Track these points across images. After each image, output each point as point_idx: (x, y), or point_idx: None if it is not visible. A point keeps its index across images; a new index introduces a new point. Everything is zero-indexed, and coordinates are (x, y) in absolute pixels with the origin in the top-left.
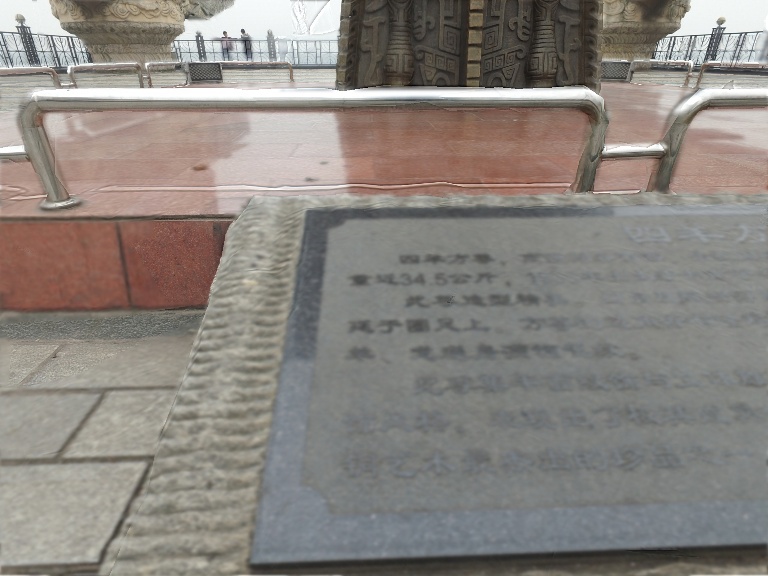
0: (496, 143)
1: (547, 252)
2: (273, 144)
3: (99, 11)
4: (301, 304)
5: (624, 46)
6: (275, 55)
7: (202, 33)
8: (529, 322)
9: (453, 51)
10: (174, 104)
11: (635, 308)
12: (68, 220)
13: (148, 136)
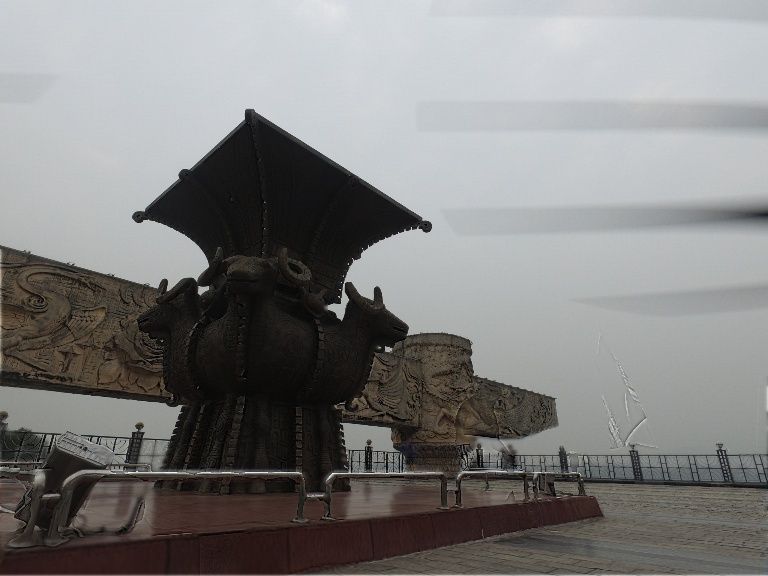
0: None
1: None
2: None
3: (410, 436)
4: None
5: None
6: (567, 468)
7: None
8: None
9: None
10: None
11: None
12: None
13: None
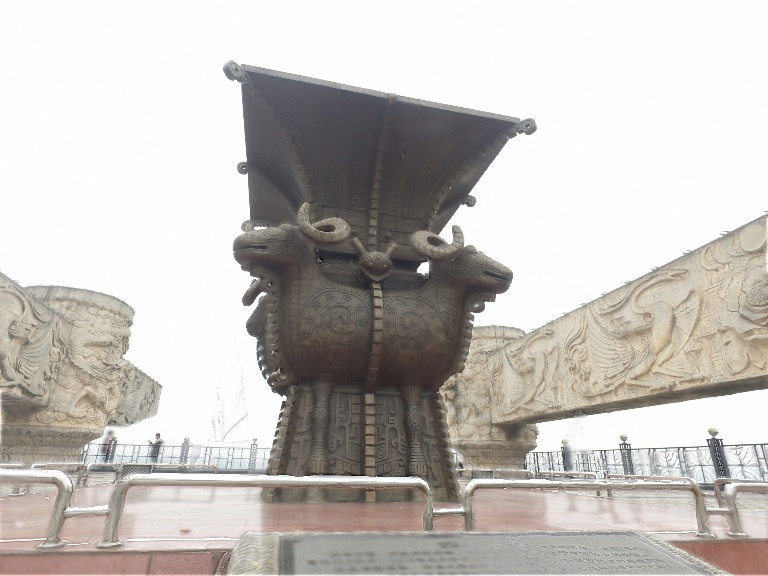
0: (385, 519)
1: (400, 551)
2: (228, 520)
3: (24, 416)
4: (284, 570)
5: (499, 459)
6: (186, 460)
7: (117, 438)
8: (388, 573)
9: (355, 459)
10: (208, 482)
11: (436, 569)
12: (119, 553)
13: (125, 516)
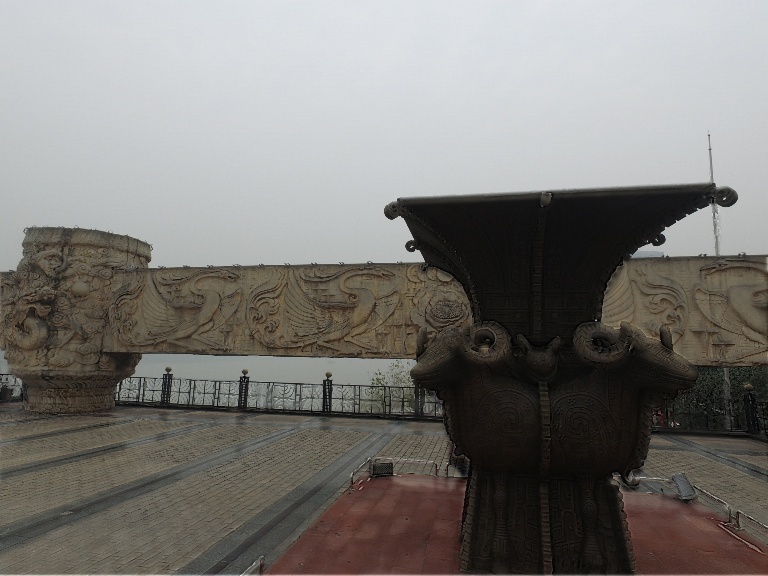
0: None
1: None
2: None
3: None
4: None
5: (96, 390)
6: None
7: None
8: None
9: None
10: None
11: None
12: None
13: None
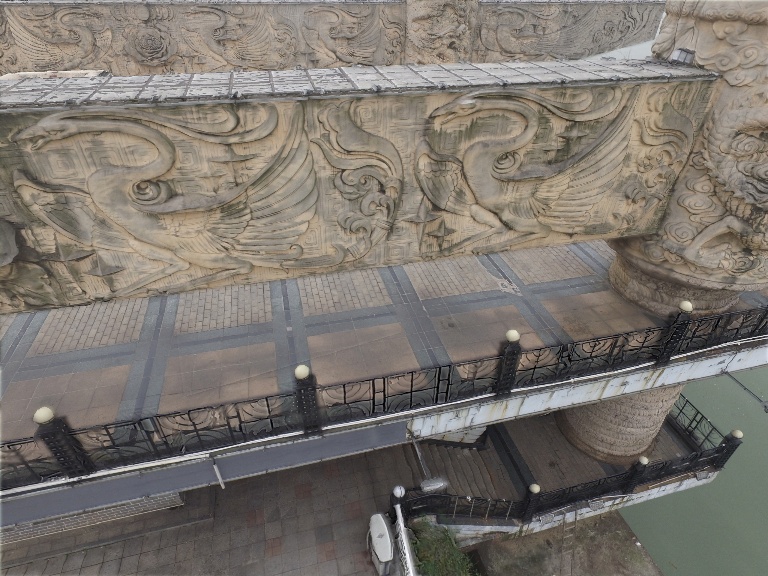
0: None
1: None
2: None
3: None
4: None
5: (622, 260)
6: None
7: None
8: None
9: None
10: None
11: None
12: None
13: None
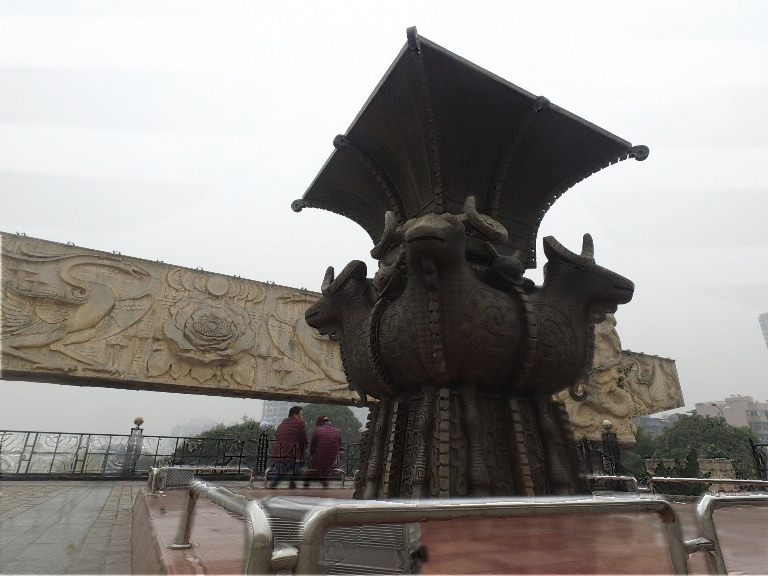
0: None
1: None
2: None
3: None
4: None
5: None
6: None
7: None
8: None
9: None
10: None
11: None
12: None
13: (752, 515)
